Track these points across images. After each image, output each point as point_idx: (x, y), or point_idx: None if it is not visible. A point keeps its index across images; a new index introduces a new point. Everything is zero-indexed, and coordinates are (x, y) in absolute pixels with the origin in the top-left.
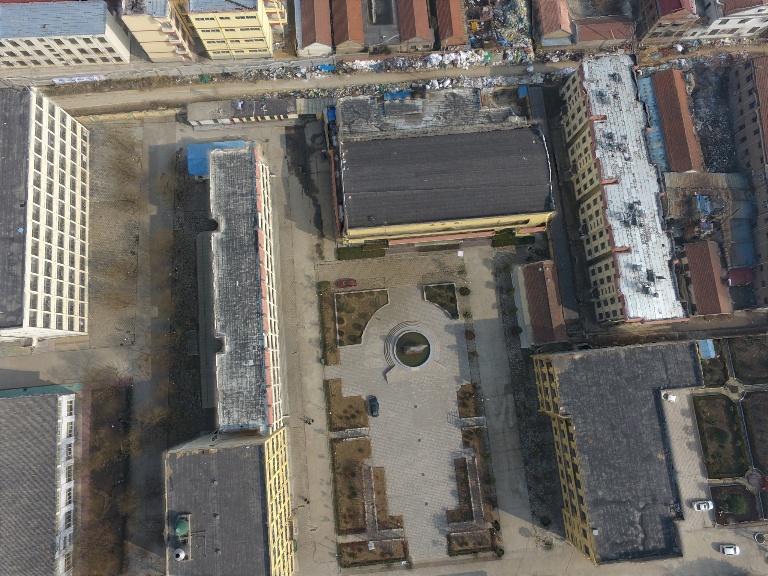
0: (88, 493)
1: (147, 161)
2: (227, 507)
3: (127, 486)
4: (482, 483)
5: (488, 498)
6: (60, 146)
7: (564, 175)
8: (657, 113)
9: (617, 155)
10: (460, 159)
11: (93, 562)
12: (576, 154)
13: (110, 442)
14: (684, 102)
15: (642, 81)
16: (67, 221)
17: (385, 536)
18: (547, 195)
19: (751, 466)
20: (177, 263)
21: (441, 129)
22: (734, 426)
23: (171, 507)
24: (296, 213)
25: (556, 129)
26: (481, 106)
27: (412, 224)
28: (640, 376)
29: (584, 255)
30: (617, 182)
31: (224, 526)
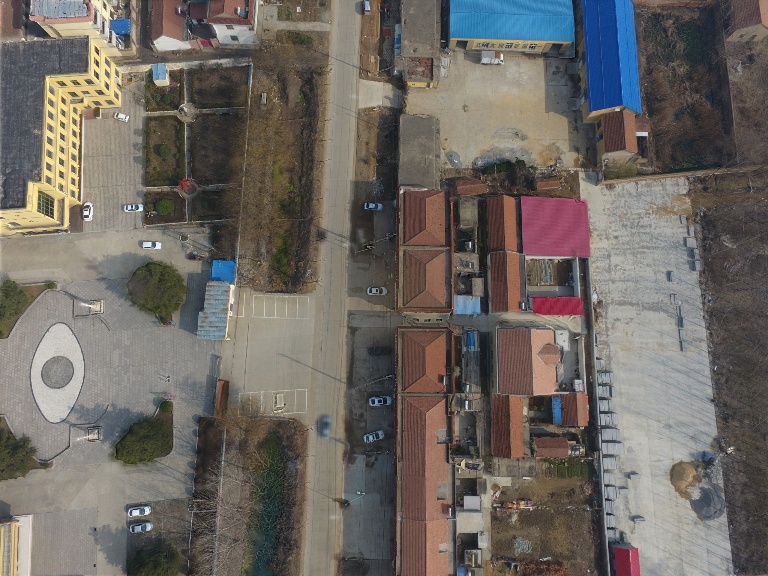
0: None
1: None
2: None
3: None
4: None
5: None
6: None
7: None
8: None
9: None
10: None
11: None
12: None
13: None
14: None
15: None
16: None
17: None
18: None
19: (190, 178)
20: None
21: None
22: (176, 141)
23: None
24: None
25: None
26: None
27: None
28: (34, 65)
29: None
30: None
31: None
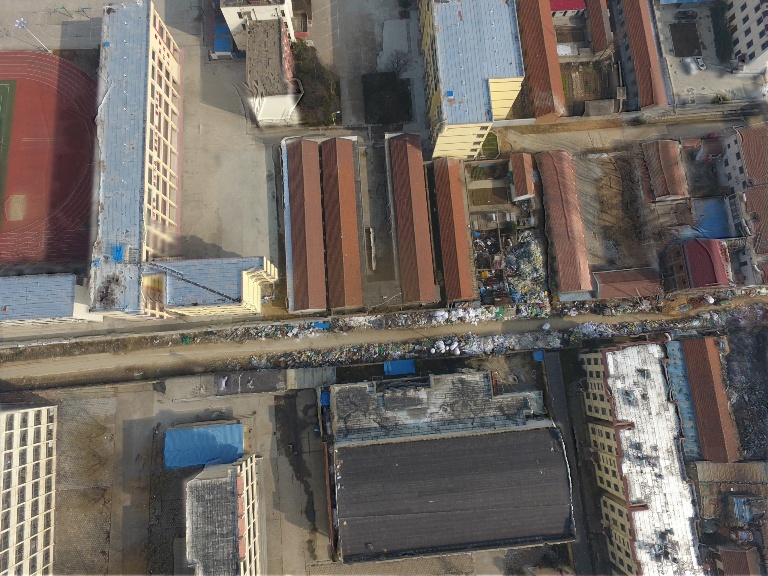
0: None
1: (121, 439)
2: None
3: None
4: None
5: None
6: (20, 456)
7: (584, 453)
8: (687, 386)
9: (646, 470)
10: (469, 474)
11: None
12: (598, 439)
13: None
14: (718, 376)
15: (670, 345)
16: (27, 541)
17: None
18: (567, 516)
19: None
20: (152, 565)
21: (448, 423)
22: None
23: None
24: (286, 502)
25: (575, 396)
26: (492, 396)
27: (415, 557)
28: None
29: (606, 553)
30: (647, 507)
31: None
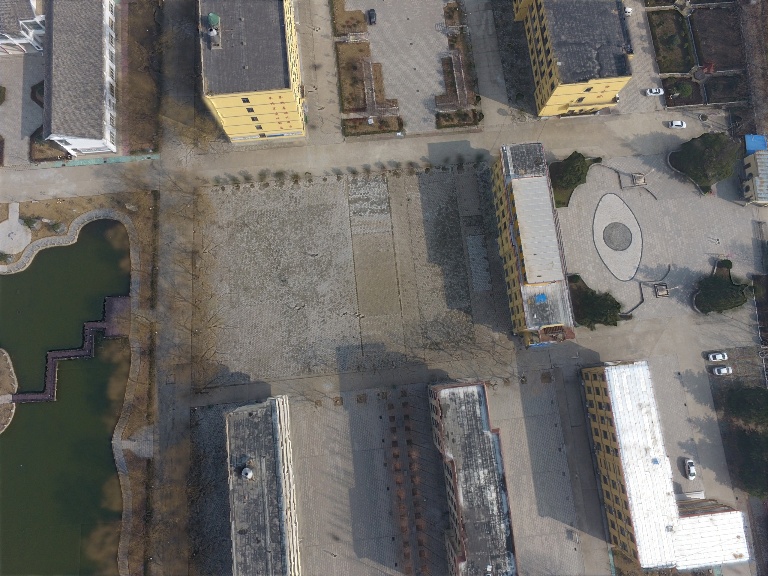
0: (127, 79)
1: None
2: (250, 14)
3: (161, 66)
4: (465, 74)
5: (471, 86)
6: None
7: None
8: None
9: None
10: None
11: (133, 130)
12: None
13: (145, 41)
14: None
15: None
16: None
17: (382, 114)
18: None
19: (697, 65)
20: None
21: None
22: (682, 32)
23: (204, 13)
24: None
25: None
26: None
27: None
28: None
29: None
30: None
31: (248, 27)
